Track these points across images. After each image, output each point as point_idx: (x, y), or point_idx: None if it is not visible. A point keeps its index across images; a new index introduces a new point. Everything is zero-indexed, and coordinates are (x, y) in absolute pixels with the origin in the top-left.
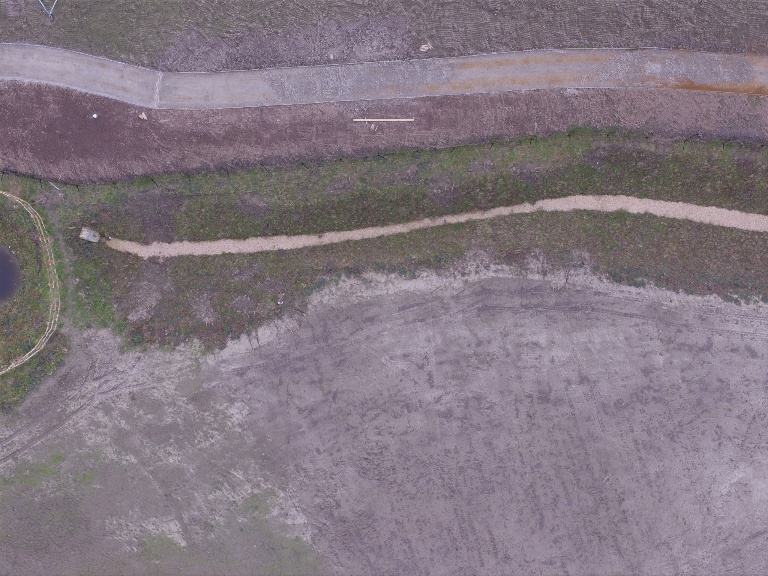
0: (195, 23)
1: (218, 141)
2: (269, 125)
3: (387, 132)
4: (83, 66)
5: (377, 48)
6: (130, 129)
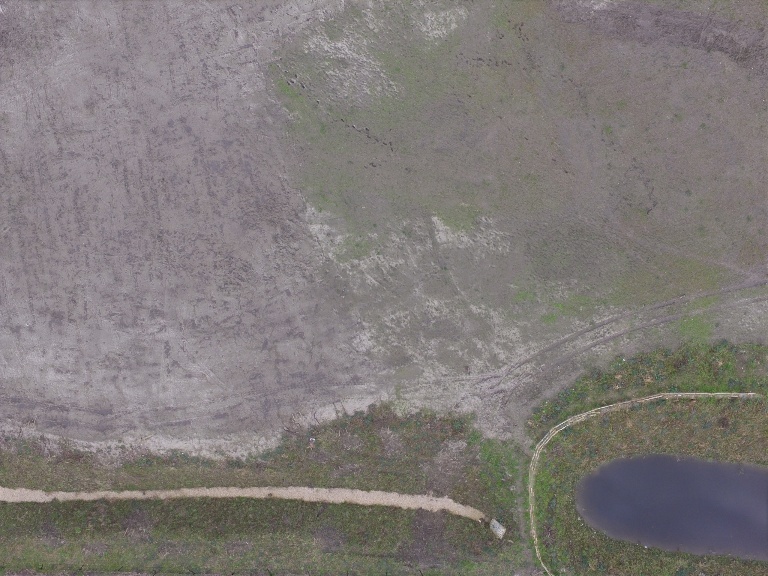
0: None
1: None
2: None
3: None
4: None
5: None
6: None
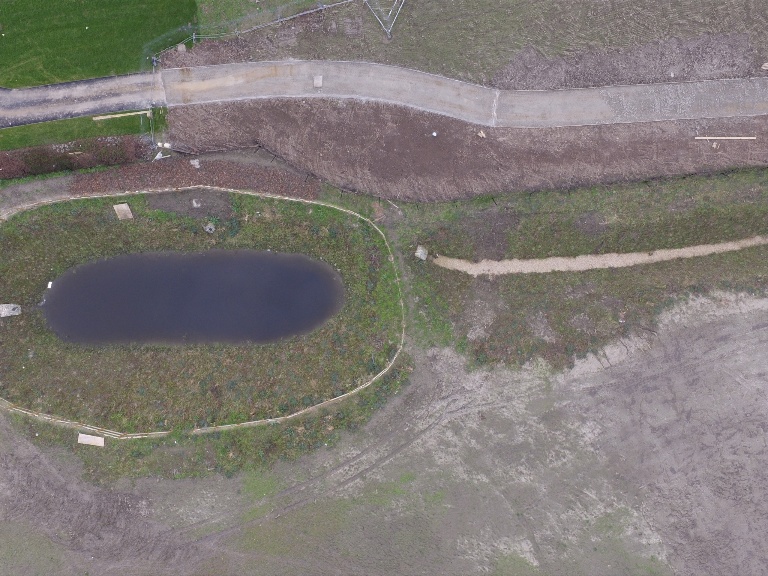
0: (534, 41)
1: (557, 159)
2: (608, 143)
3: (729, 150)
4: (419, 84)
5: (718, 66)
6: (468, 147)
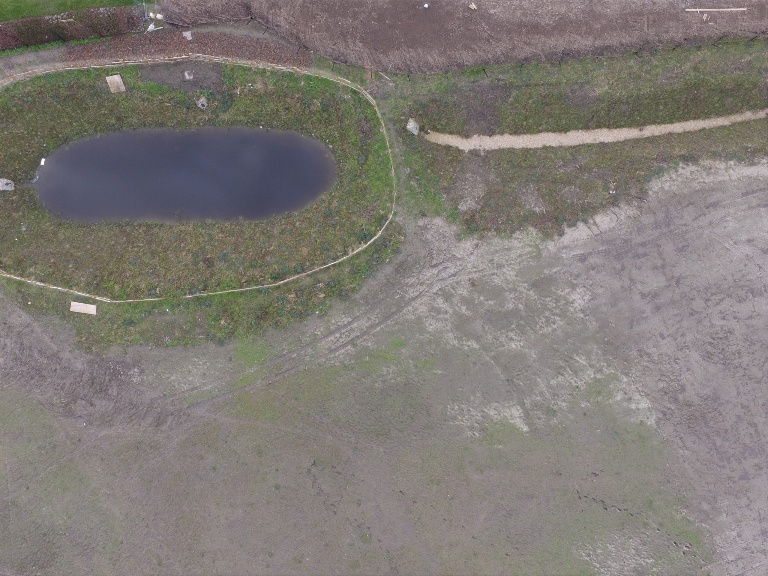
0: None
1: (548, 31)
2: (599, 15)
3: (720, 22)
4: None
5: None
6: (460, 19)
